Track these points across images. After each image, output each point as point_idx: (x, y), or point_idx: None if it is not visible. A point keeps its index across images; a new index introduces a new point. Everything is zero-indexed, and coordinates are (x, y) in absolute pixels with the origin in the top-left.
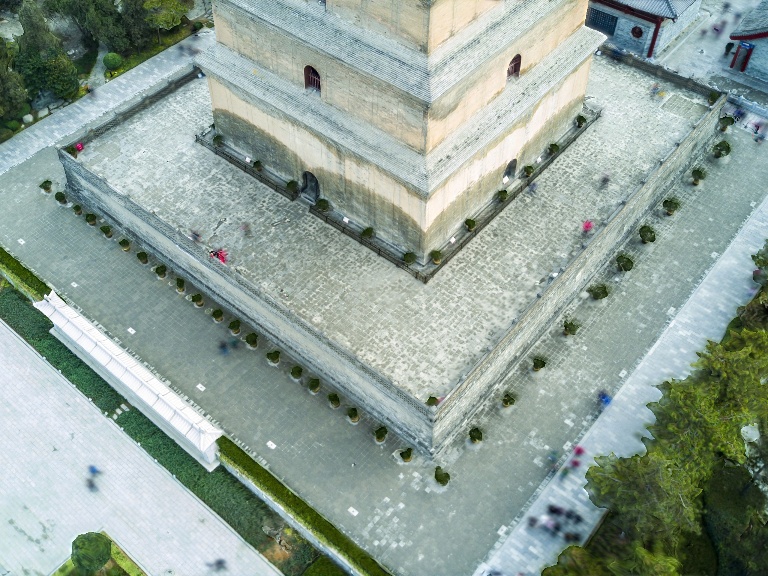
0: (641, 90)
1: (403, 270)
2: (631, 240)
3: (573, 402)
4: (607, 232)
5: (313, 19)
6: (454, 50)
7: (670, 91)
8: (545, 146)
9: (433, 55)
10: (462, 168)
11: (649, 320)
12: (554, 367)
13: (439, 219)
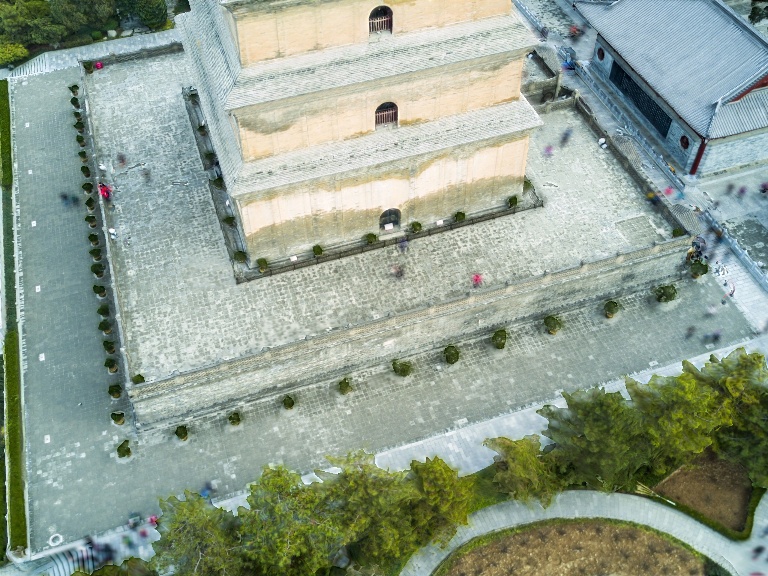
0: (612, 198)
1: (231, 264)
2: (488, 339)
3: (292, 452)
4: (437, 314)
5: (207, 6)
6: (279, 71)
7: (643, 211)
8: (454, 211)
9: (251, 68)
10: (298, 191)
11: (432, 418)
12: (306, 414)
13: (270, 231)
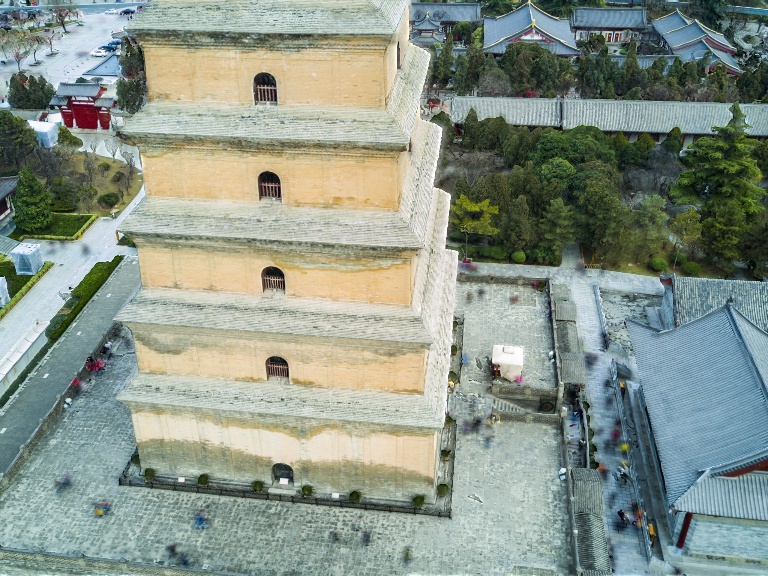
0: (532, 537)
1: None
2: None
3: None
4: None
5: None
6: (173, 300)
7: (556, 564)
8: (353, 489)
9: (151, 291)
10: (186, 414)
11: None
12: None
13: (160, 444)
